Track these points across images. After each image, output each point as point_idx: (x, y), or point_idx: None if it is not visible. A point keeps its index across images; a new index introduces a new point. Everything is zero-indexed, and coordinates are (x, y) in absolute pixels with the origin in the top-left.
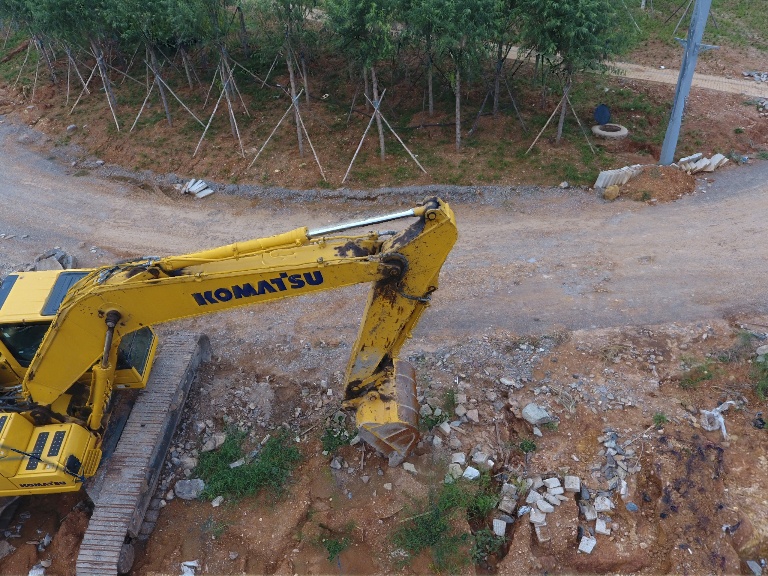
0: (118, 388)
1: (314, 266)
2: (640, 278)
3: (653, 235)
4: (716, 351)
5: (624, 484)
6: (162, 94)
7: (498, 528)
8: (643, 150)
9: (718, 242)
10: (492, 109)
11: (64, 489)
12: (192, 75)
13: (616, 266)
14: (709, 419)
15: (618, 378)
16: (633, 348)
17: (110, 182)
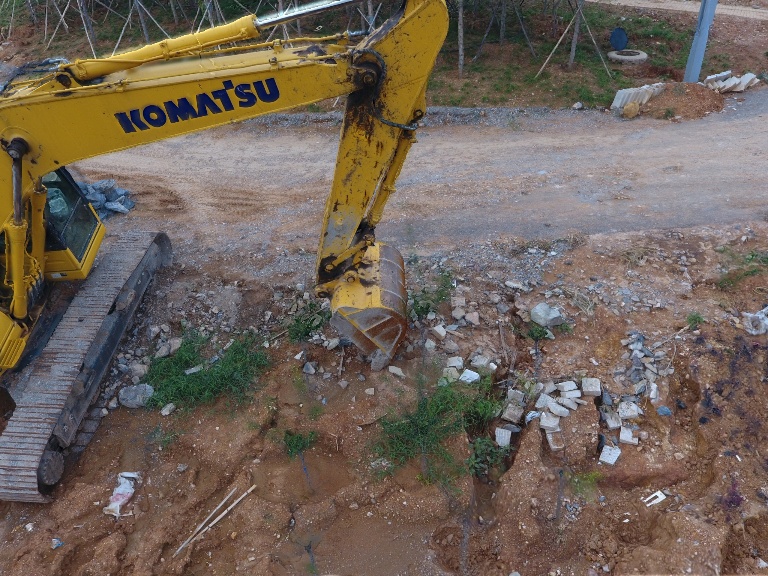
0: (53, 278)
1: (266, 70)
2: (666, 186)
3: (679, 148)
4: (758, 252)
5: (654, 387)
6: (142, 20)
7: (501, 438)
8: (664, 75)
9: (753, 152)
10: (498, 38)
11: None
12: (178, 12)
13: (638, 176)
14: (753, 322)
15: (643, 280)
16: (660, 250)
17: None
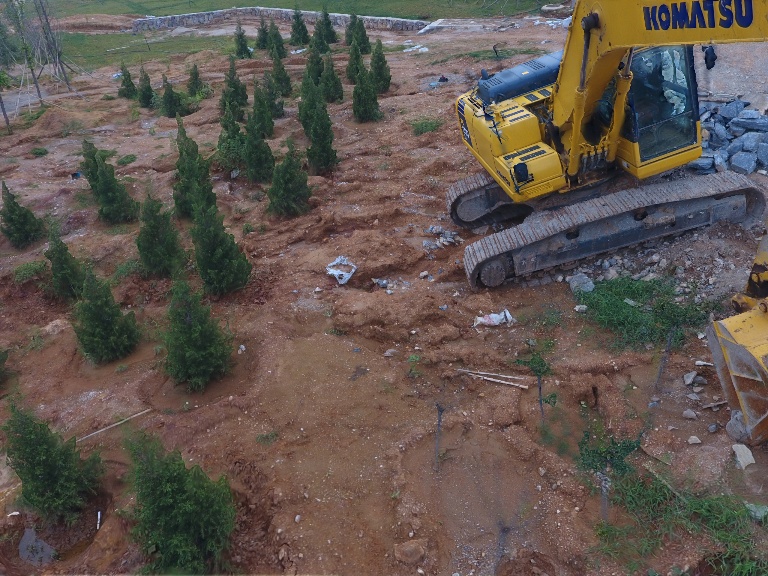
0: (623, 165)
1: None
2: None
3: None
4: None
5: None
6: None
7: None
8: None
9: None
10: None
11: None
12: None
13: None
14: None
15: None
16: None
17: None
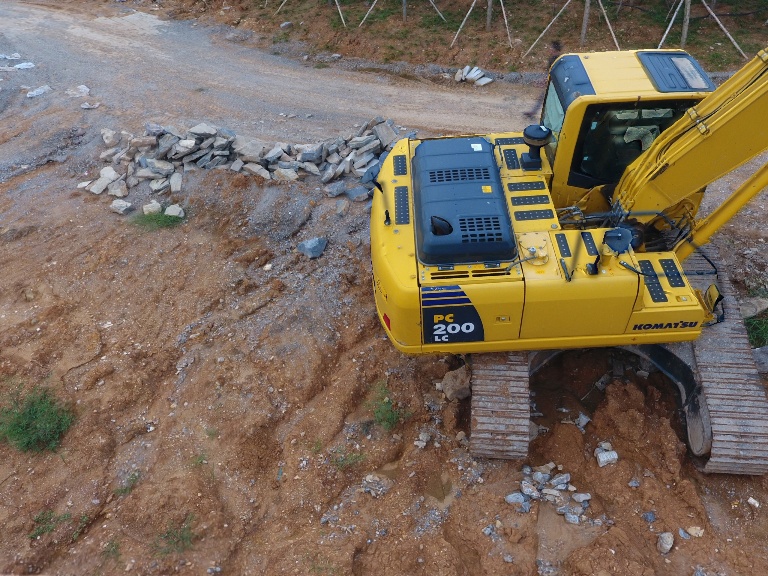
0: None
1: None
2: None
3: None
4: None
5: None
6: None
7: None
8: None
9: None
10: None
11: (683, 335)
12: None
13: None
14: None
15: None
16: None
17: (361, 73)
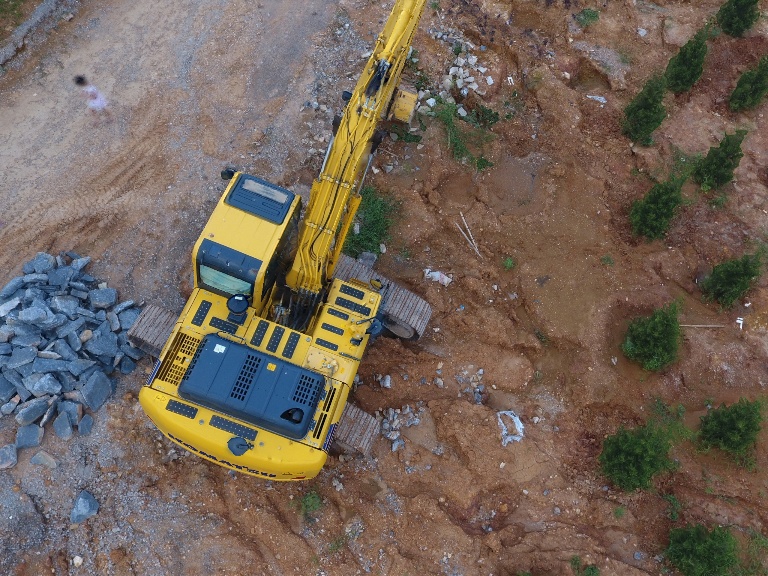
0: None
1: None
2: None
3: None
4: None
5: (469, 43)
6: None
7: (463, 113)
8: None
9: None
10: None
11: None
12: None
13: None
14: None
15: None
16: None
17: None
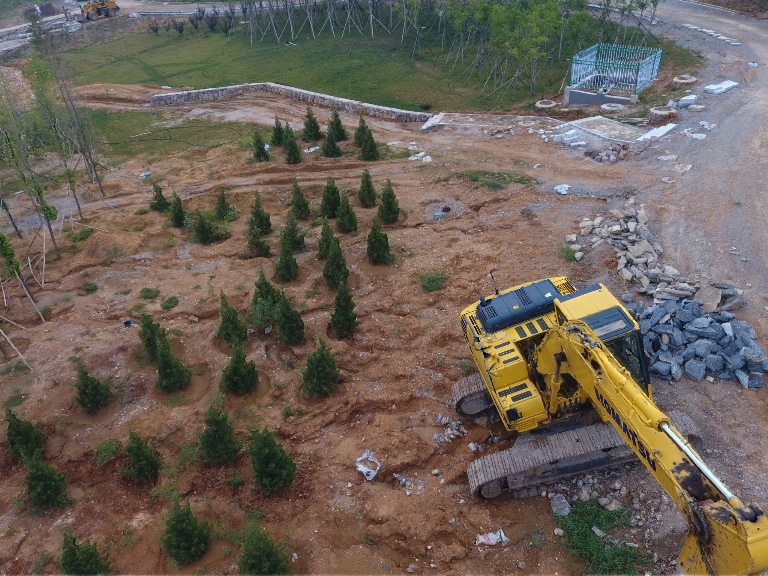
0: None
1: None
2: None
3: None
4: None
5: None
6: None
7: None
8: None
9: None
10: None
11: None
12: None
13: None
14: None
15: None
16: None
17: None
